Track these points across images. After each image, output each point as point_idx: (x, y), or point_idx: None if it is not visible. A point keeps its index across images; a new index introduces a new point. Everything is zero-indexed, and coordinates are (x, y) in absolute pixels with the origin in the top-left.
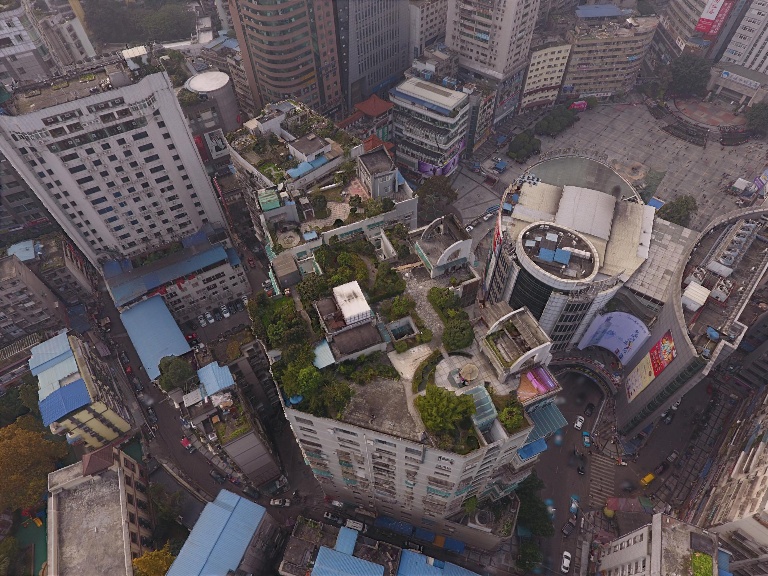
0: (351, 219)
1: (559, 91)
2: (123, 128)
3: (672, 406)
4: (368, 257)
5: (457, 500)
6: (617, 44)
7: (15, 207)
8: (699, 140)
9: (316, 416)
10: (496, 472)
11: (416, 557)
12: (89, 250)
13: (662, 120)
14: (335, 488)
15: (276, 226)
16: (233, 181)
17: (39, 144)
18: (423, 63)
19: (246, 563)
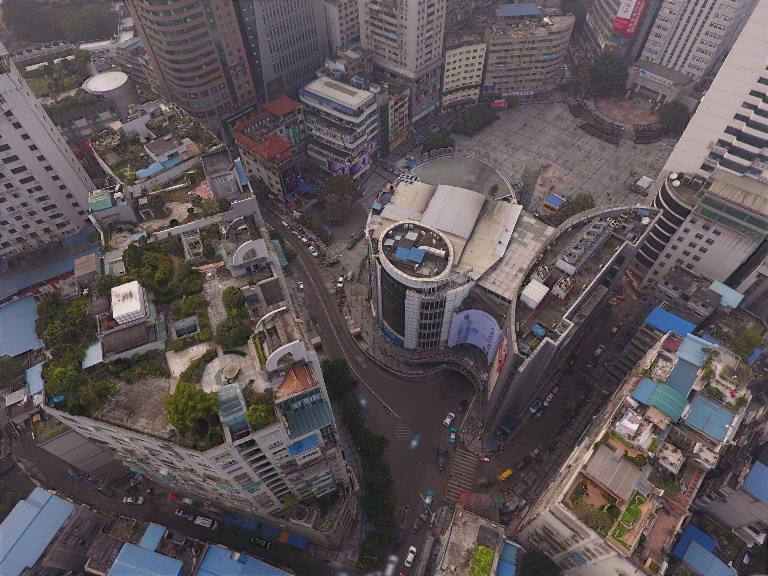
0: (188, 219)
1: (481, 90)
2: None
3: (543, 402)
4: (178, 257)
5: (258, 496)
6: (532, 43)
7: None
8: (613, 138)
9: (71, 414)
10: (282, 468)
11: (221, 552)
12: None
13: (580, 118)
14: (170, 485)
15: (111, 226)
16: None
17: None
18: (334, 62)
19: (56, 560)
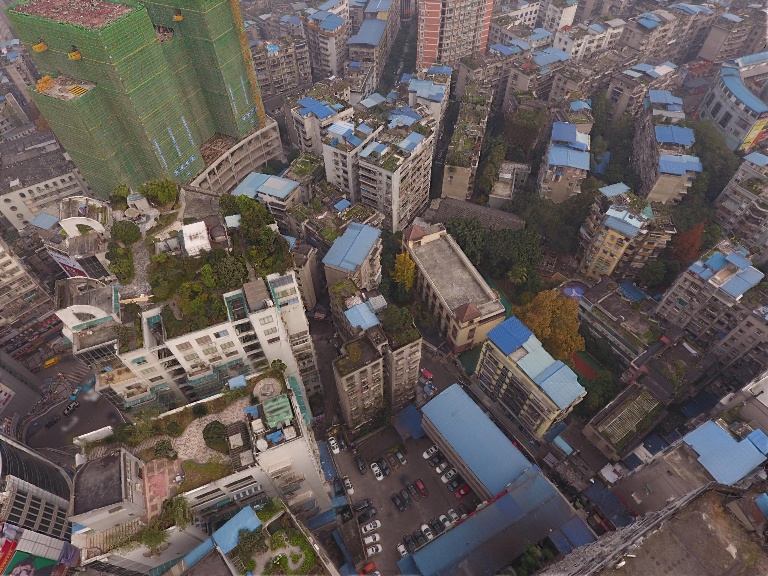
0: (182, 420)
1: None
2: None
3: None
4: None
5: None
6: None
7: None
8: None
9: None
10: None
11: None
12: None
13: None
14: None
15: None
16: None
17: None
18: None
19: None
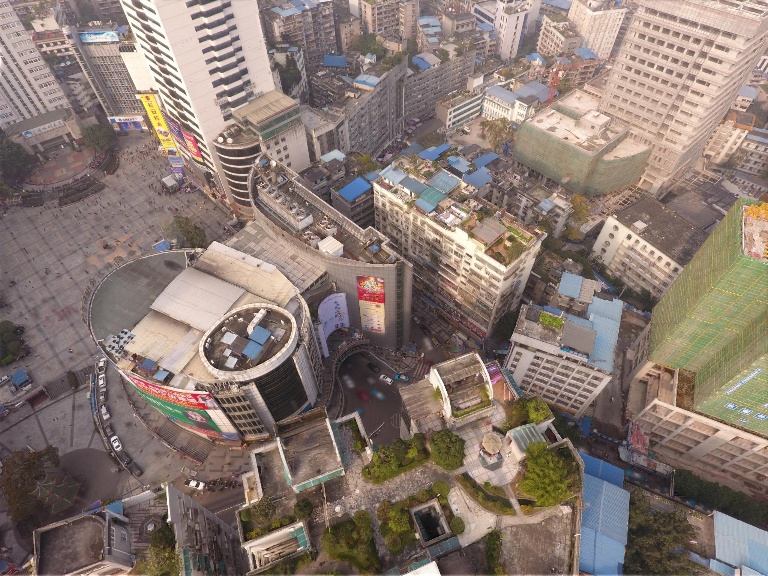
0: None
1: None
2: None
3: None
4: None
5: None
6: None
7: None
8: (95, 187)
9: None
10: None
11: None
12: None
13: (47, 202)
14: None
15: None
16: None
17: None
18: None
19: None
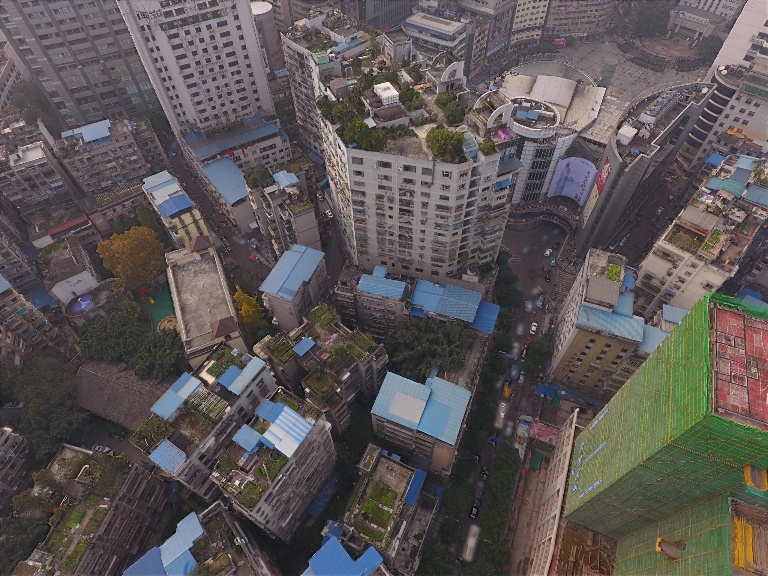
0: None
1: (543, 31)
2: (211, 16)
3: (620, 243)
4: (394, 84)
5: (454, 241)
6: None
7: (105, 104)
8: (658, 68)
9: (366, 151)
10: (480, 211)
11: (427, 283)
12: (175, 121)
13: (629, 54)
14: (368, 263)
15: (326, 78)
16: (278, 84)
17: (155, 22)
18: (428, 1)
19: (312, 289)
